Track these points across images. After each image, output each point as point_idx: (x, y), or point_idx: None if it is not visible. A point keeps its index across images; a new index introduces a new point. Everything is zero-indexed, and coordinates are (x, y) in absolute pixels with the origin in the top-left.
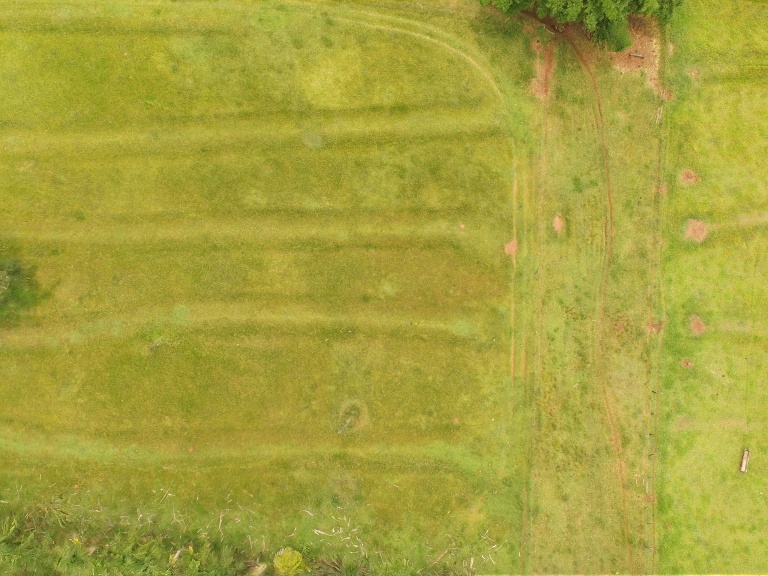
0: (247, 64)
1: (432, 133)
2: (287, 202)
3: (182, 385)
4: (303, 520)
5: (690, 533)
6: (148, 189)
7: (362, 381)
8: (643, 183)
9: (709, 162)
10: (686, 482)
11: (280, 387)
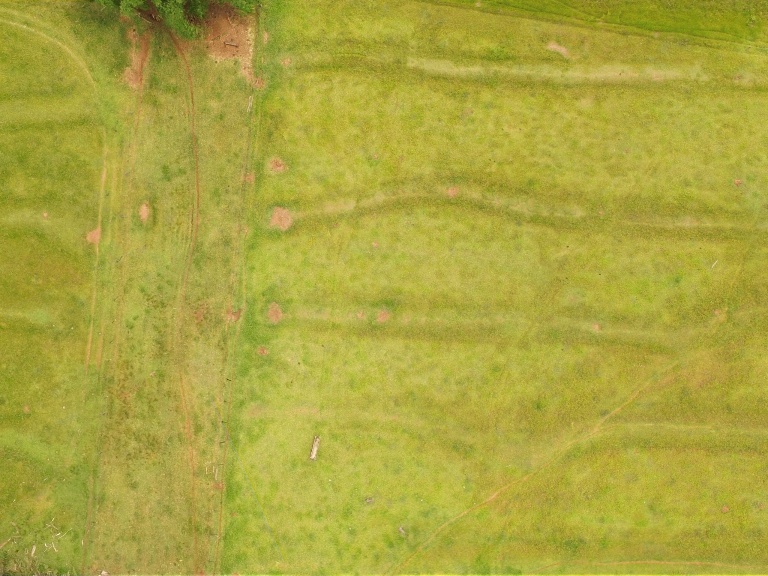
0: None
1: (23, 122)
2: None
3: None
4: None
5: (256, 520)
6: None
7: None
8: (232, 171)
9: (297, 150)
10: (256, 469)
11: None
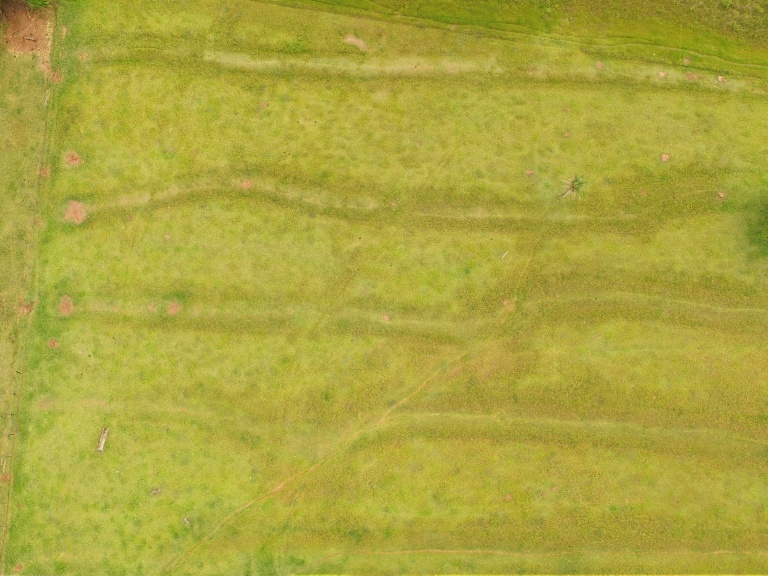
0: None
1: None
2: None
3: None
4: None
5: (42, 512)
6: None
7: None
8: (28, 165)
9: (93, 144)
10: (44, 461)
11: None
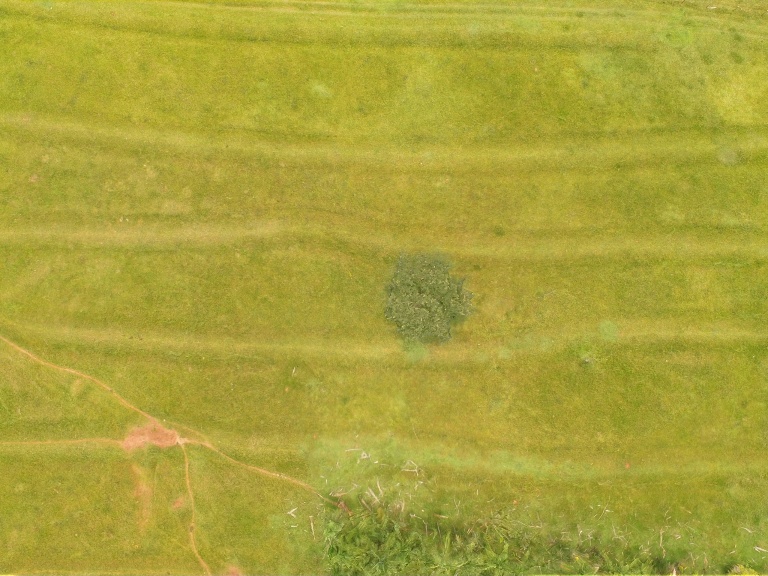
0: (657, 80)
1: None
2: (706, 218)
3: (613, 401)
4: (742, 537)
5: None
6: (565, 205)
7: None
8: None
9: None
10: None
11: (711, 404)
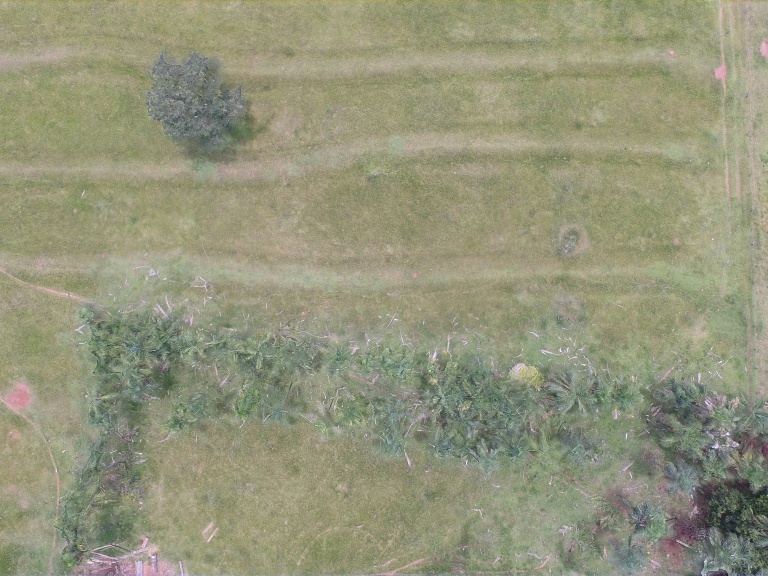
0: None
1: None
2: (495, 34)
3: (402, 214)
4: (529, 341)
5: None
6: (355, 25)
7: (580, 205)
8: None
9: None
10: None
11: (499, 213)
